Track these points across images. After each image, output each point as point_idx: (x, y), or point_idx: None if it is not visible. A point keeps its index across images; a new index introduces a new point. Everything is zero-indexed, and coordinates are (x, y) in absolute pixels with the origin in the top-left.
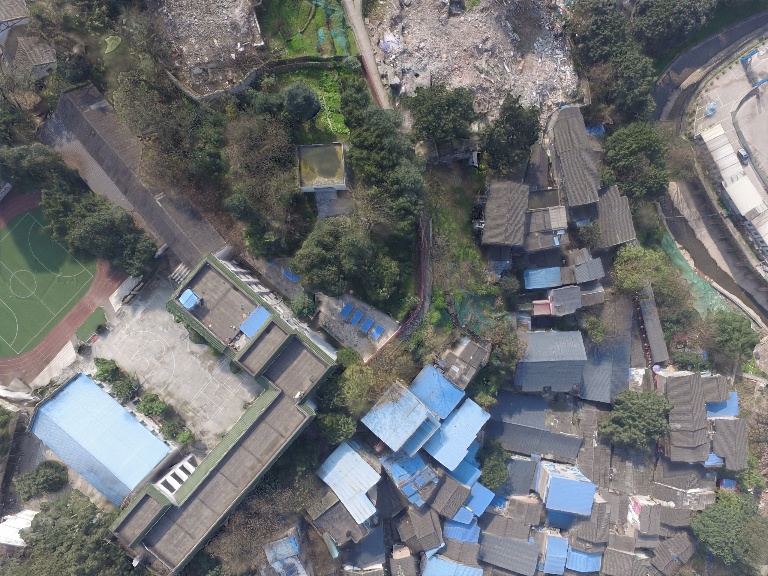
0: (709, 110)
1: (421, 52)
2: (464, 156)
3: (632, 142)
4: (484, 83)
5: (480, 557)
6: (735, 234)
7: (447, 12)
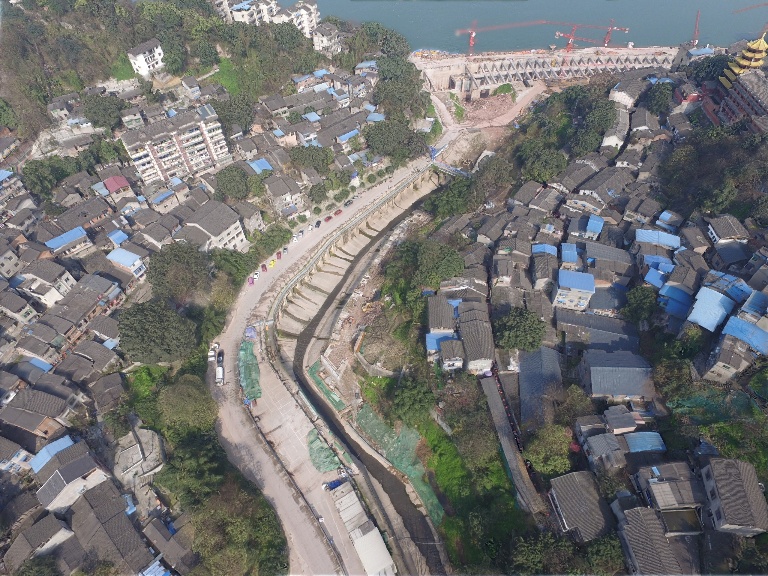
0: None
1: None
2: None
3: None
4: None
5: (628, 252)
6: (376, 511)
7: None
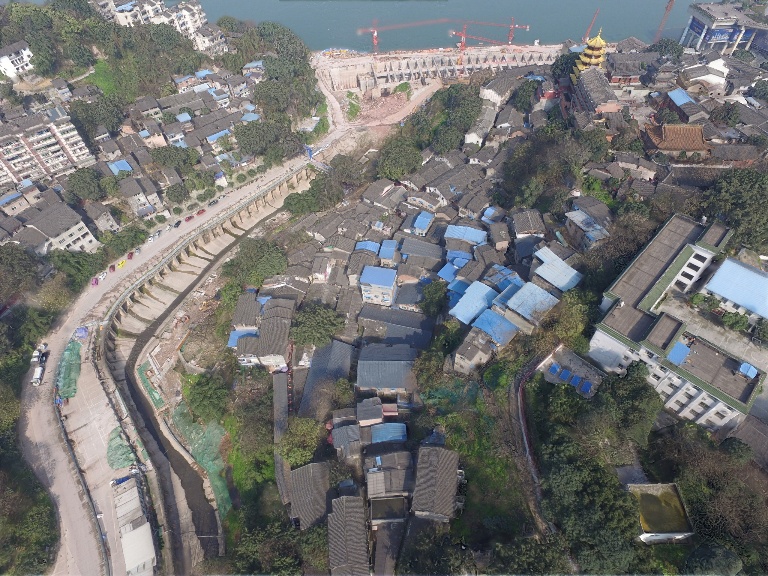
0: None
1: None
2: None
3: None
4: None
5: (442, 248)
6: (159, 506)
7: None
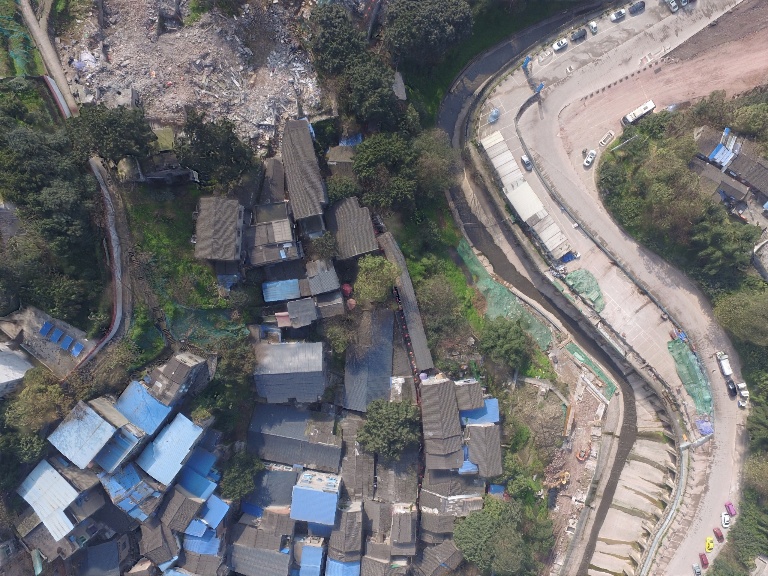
0: (491, 117)
1: (124, 70)
2: (178, 172)
3: (369, 153)
4: (204, 98)
5: (232, 568)
6: (524, 240)
7: (156, 29)
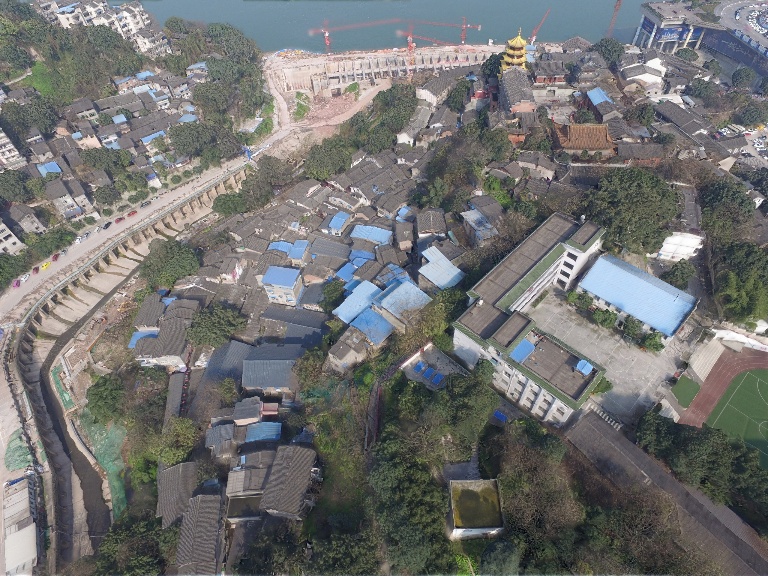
0: None
1: None
2: None
3: None
4: None
5: None
6: (51, 507)
7: None
